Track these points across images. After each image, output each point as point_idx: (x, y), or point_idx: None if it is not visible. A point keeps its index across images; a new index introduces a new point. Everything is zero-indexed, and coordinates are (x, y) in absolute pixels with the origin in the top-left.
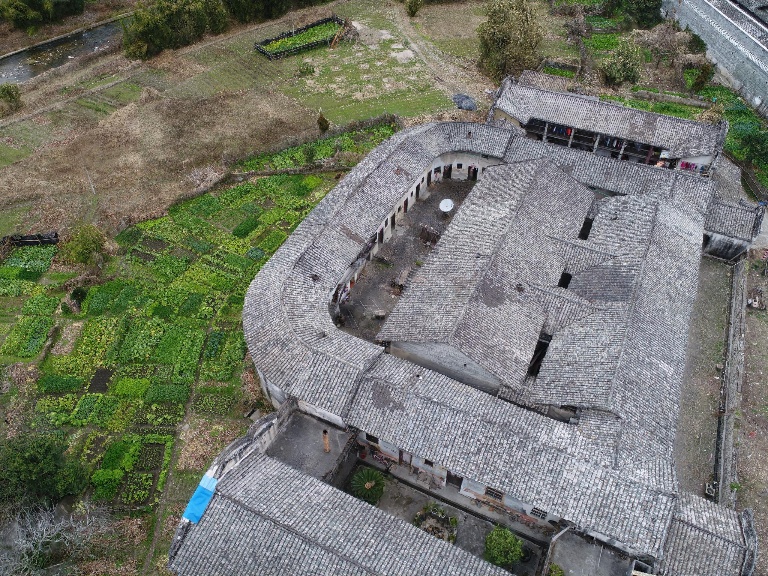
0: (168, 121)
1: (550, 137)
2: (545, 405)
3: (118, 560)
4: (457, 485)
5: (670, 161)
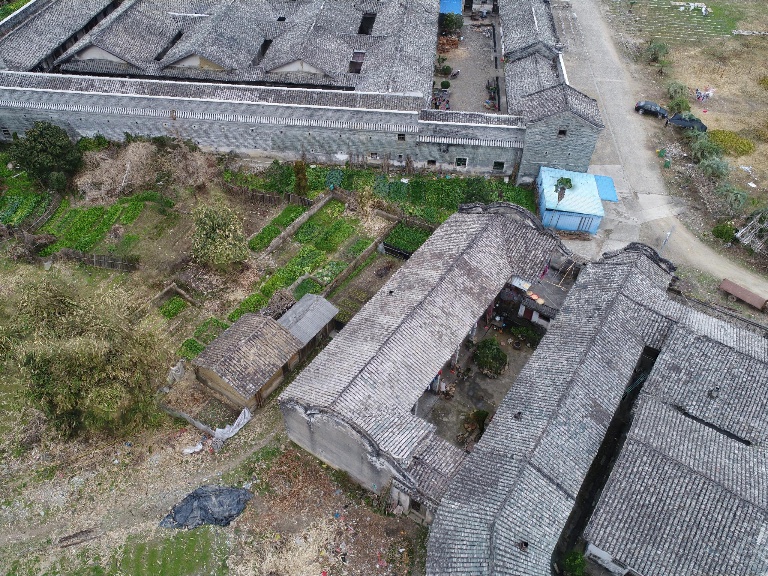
0: None
1: None
2: None
3: None
4: None
5: None
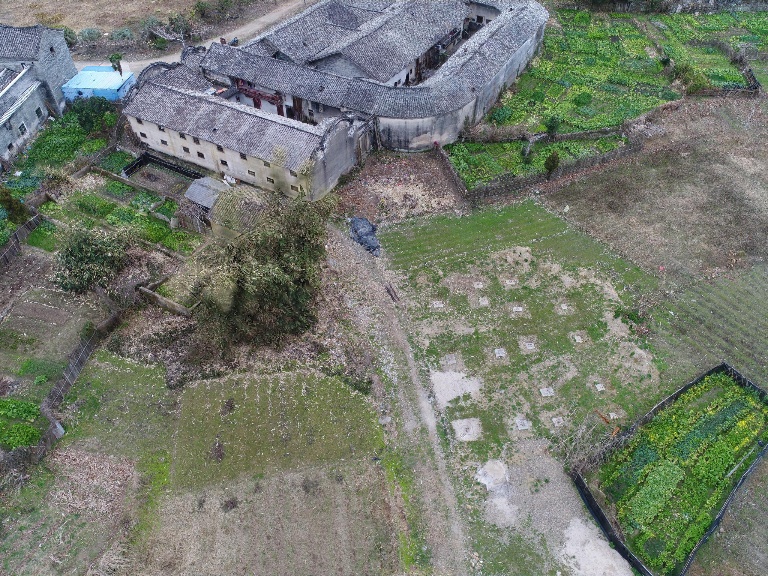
0: (765, 217)
1: None
2: None
3: (562, 4)
4: None
5: None
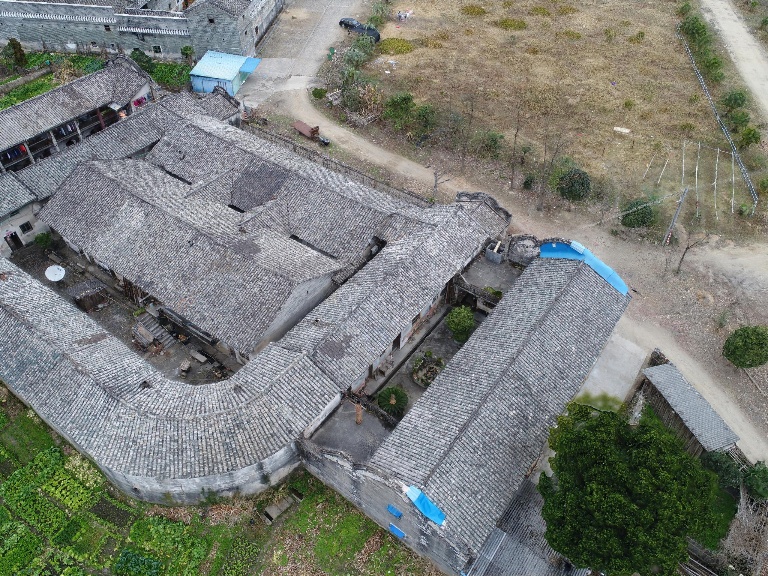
0: None
1: (9, 167)
2: (360, 257)
3: None
4: (395, 348)
5: (125, 108)
